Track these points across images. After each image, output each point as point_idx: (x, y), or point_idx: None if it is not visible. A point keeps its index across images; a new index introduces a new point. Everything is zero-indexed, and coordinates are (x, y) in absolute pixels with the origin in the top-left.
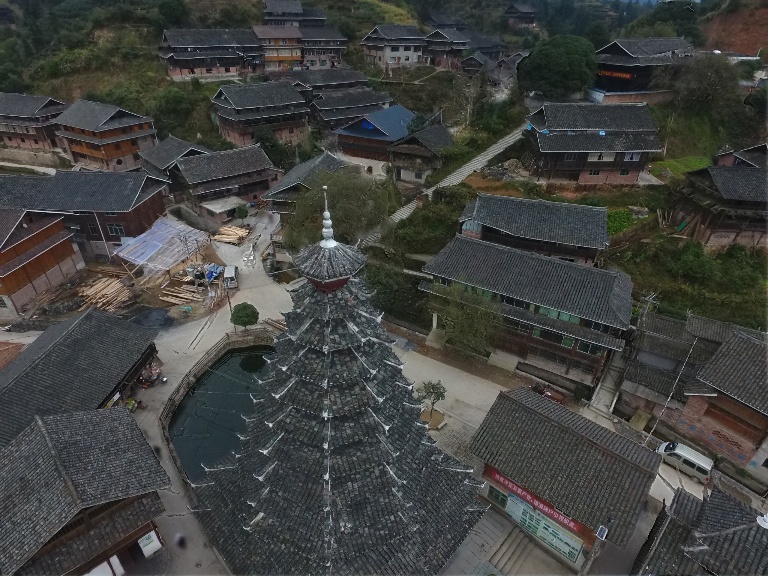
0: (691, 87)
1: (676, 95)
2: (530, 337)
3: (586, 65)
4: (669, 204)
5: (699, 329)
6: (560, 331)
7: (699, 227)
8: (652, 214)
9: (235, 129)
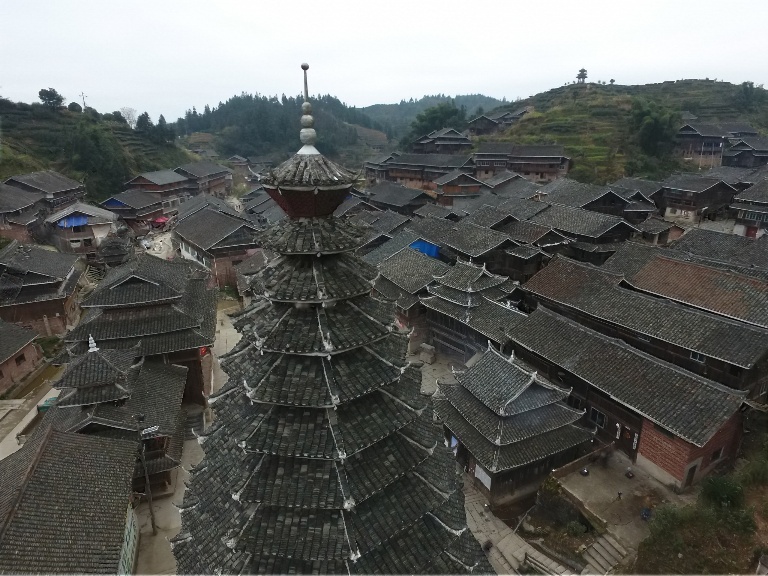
0: None
1: None
2: None
3: None
4: None
5: None
6: None
7: None
8: None
9: None
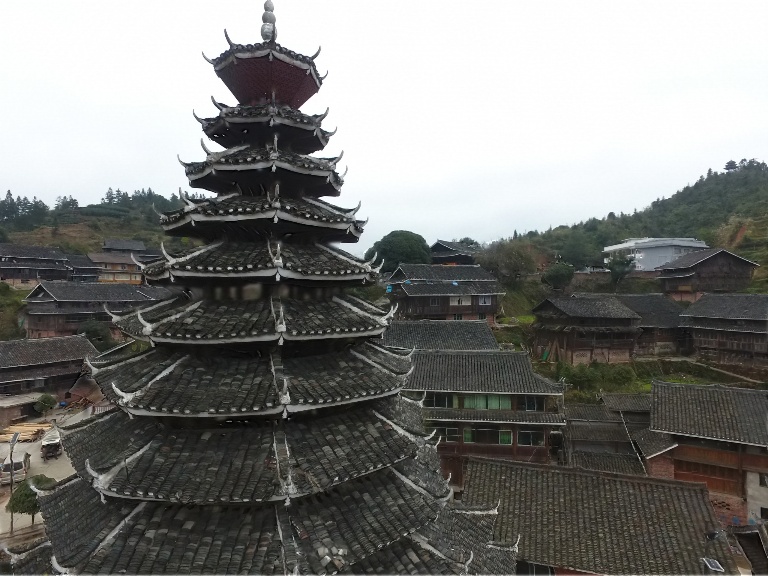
0: (505, 261)
1: (494, 275)
2: (461, 445)
3: (423, 248)
4: (526, 342)
5: (618, 403)
6: (495, 420)
7: (560, 351)
8: (518, 348)
9: (51, 326)
